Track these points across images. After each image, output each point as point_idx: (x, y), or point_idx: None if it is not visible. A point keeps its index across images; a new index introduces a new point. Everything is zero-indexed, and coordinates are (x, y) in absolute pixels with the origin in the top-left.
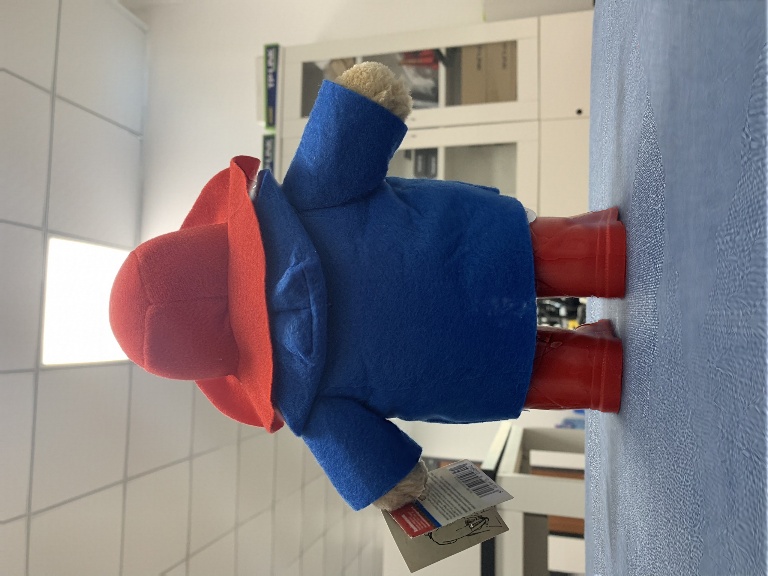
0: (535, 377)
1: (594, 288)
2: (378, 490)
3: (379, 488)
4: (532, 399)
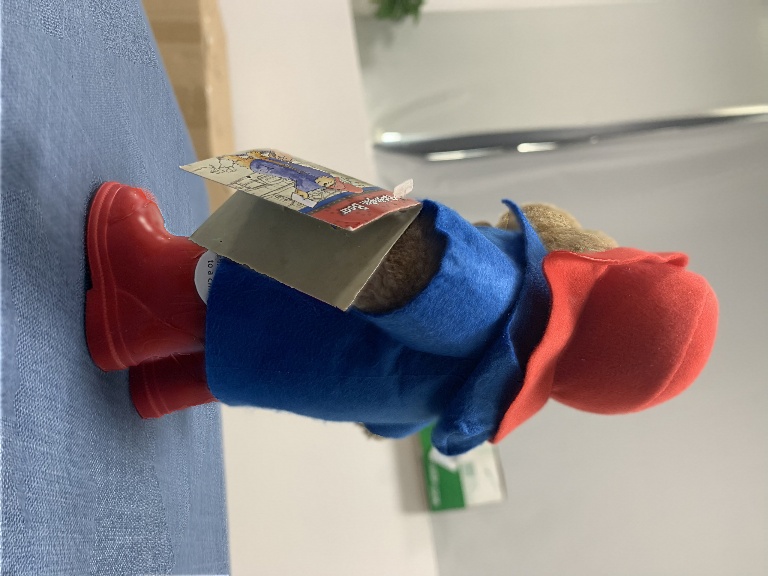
0: (201, 362)
1: (162, 393)
2: (399, 319)
3: (397, 320)
4: (197, 327)
